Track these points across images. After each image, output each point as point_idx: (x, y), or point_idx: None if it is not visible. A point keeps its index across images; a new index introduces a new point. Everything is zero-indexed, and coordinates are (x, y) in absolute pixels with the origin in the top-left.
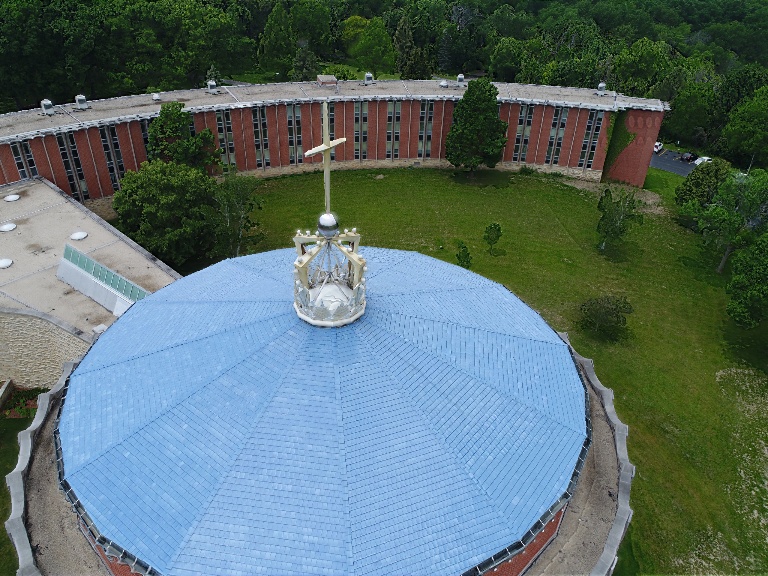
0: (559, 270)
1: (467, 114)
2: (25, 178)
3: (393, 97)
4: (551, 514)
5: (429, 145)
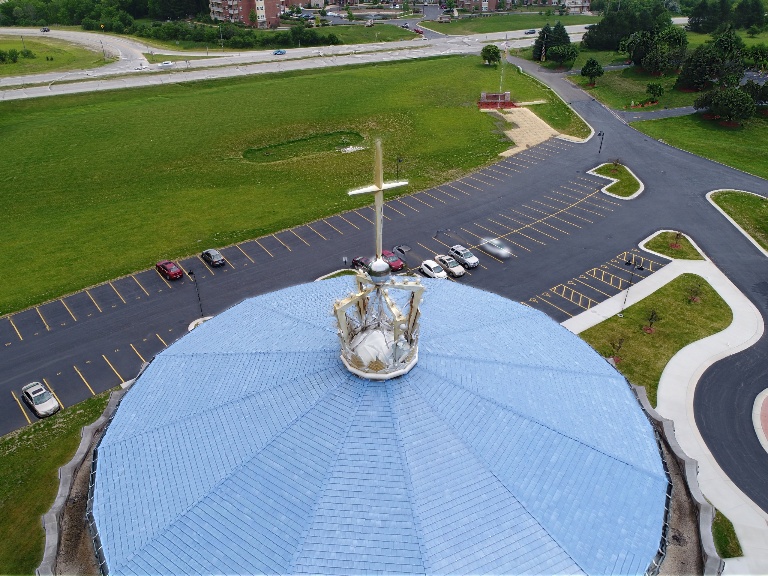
0: None
1: None
2: None
3: None
4: None
5: None
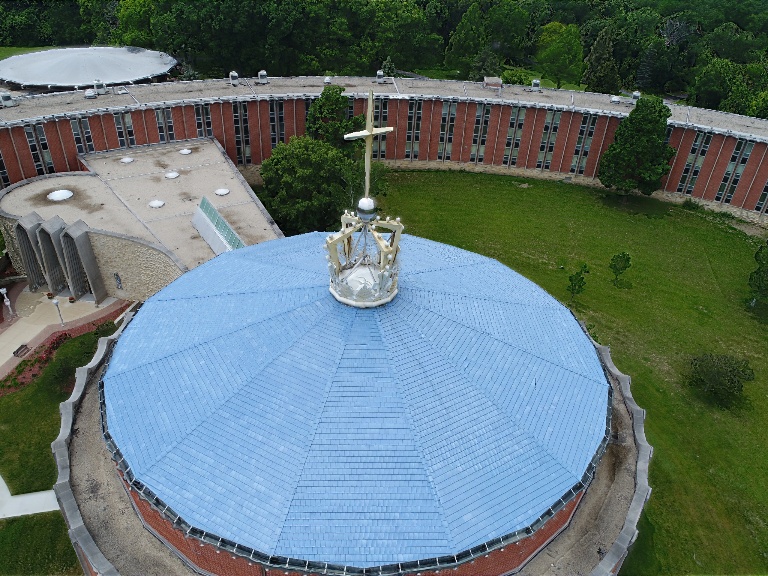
0: (688, 317)
1: (629, 133)
2: (201, 137)
3: (554, 106)
4: (501, 543)
5: (585, 161)
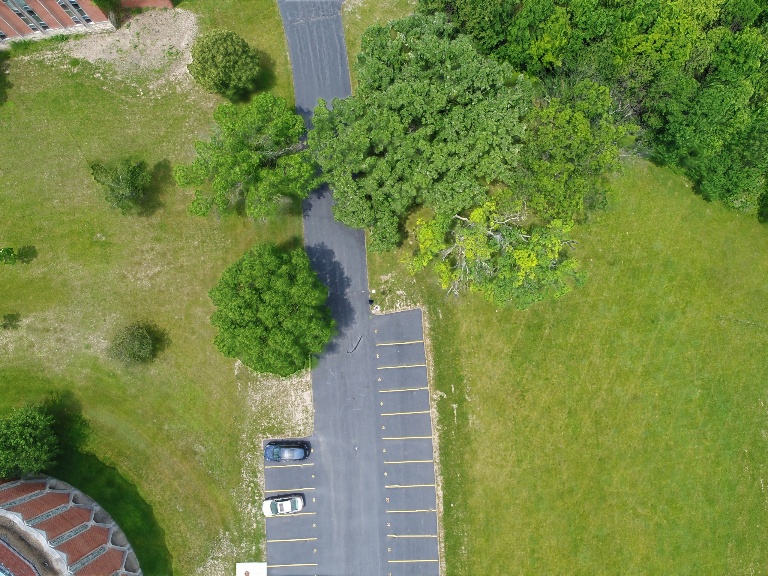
0: (94, 261)
1: None
2: None
3: None
4: None
5: None
